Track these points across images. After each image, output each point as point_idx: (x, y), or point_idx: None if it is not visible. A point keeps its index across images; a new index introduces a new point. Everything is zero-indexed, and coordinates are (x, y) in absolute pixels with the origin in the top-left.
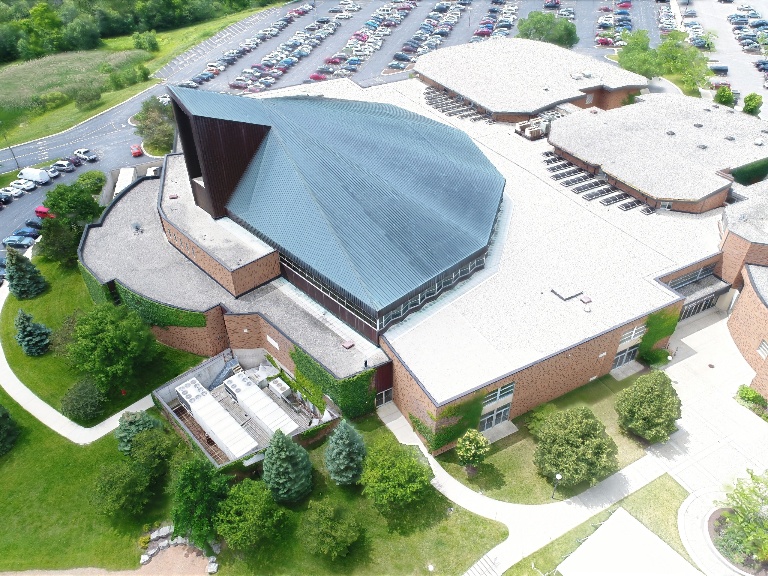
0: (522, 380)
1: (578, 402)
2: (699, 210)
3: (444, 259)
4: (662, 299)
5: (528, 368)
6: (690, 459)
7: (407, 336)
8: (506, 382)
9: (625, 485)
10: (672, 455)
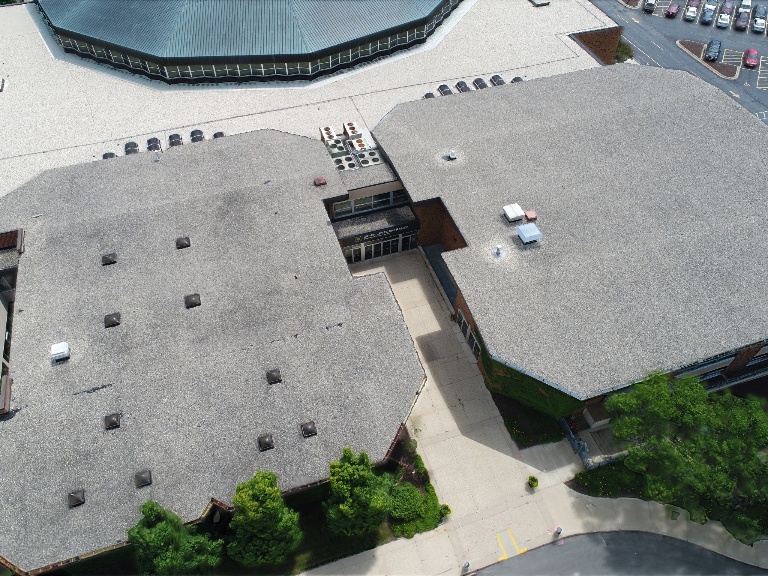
0: None
1: None
2: None
3: (49, 1)
4: None
5: None
6: None
7: (23, 11)
8: None
9: None
10: None
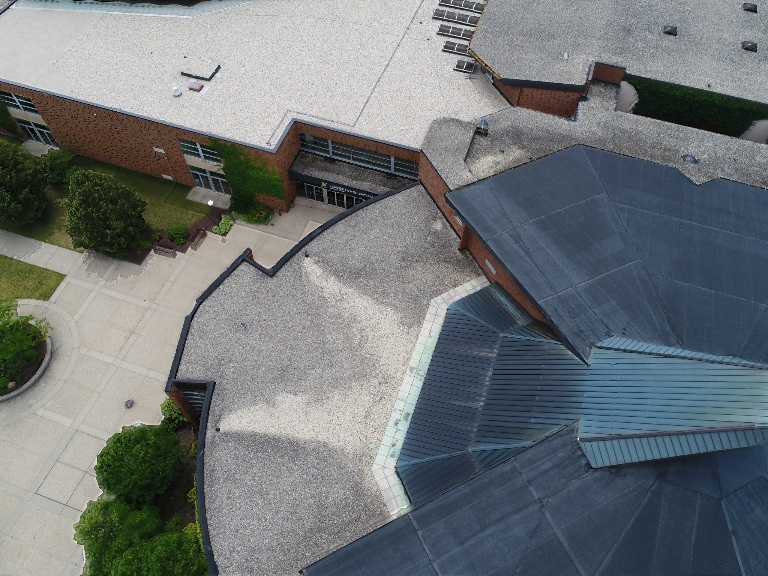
0: (41, 104)
1: (126, 182)
2: (516, 102)
3: None
4: (255, 137)
5: (37, 92)
6: (98, 286)
7: (29, 11)
8: (15, 91)
9: (28, 252)
10: (94, 271)
